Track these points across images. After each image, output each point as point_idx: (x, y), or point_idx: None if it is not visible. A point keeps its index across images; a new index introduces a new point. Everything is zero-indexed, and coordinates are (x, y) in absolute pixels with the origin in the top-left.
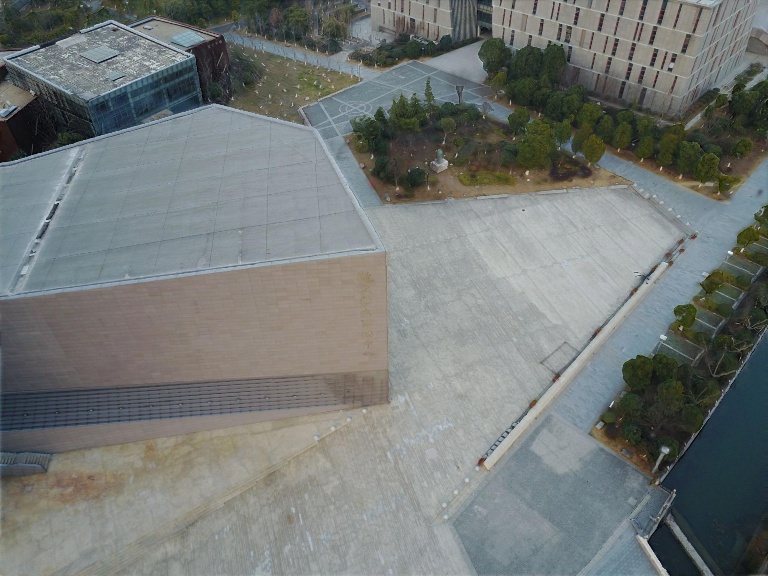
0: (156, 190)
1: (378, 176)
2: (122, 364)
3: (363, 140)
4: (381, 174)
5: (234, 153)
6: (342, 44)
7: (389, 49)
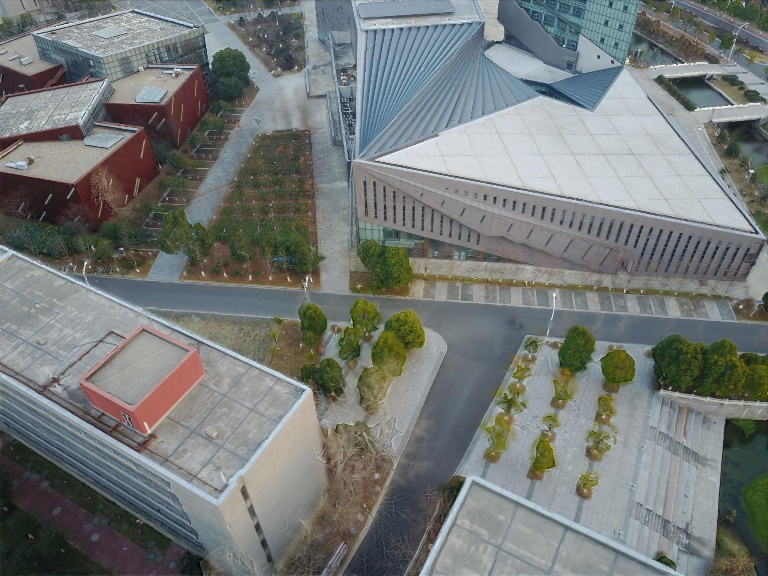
0: None
1: (274, 5)
2: None
3: (230, 9)
4: (276, 2)
5: None
6: None
7: (89, 4)
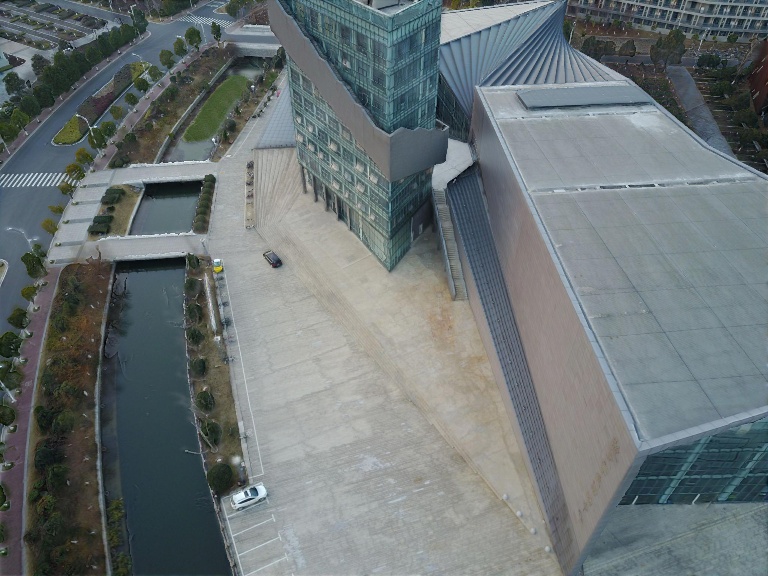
0: (699, 239)
1: None
2: (521, 298)
3: None
4: None
5: None
6: None
7: None
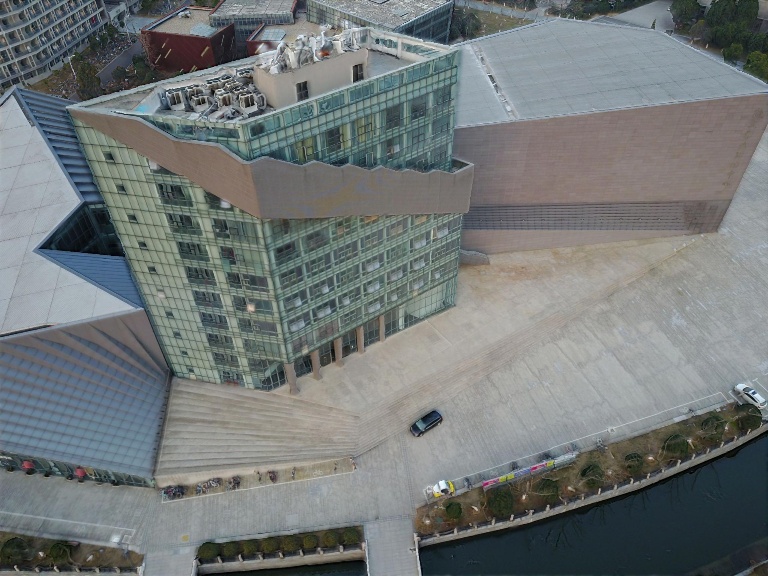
0: (564, 66)
1: None
2: (555, 184)
3: None
4: None
5: (605, 45)
6: (536, 2)
7: (580, 6)
